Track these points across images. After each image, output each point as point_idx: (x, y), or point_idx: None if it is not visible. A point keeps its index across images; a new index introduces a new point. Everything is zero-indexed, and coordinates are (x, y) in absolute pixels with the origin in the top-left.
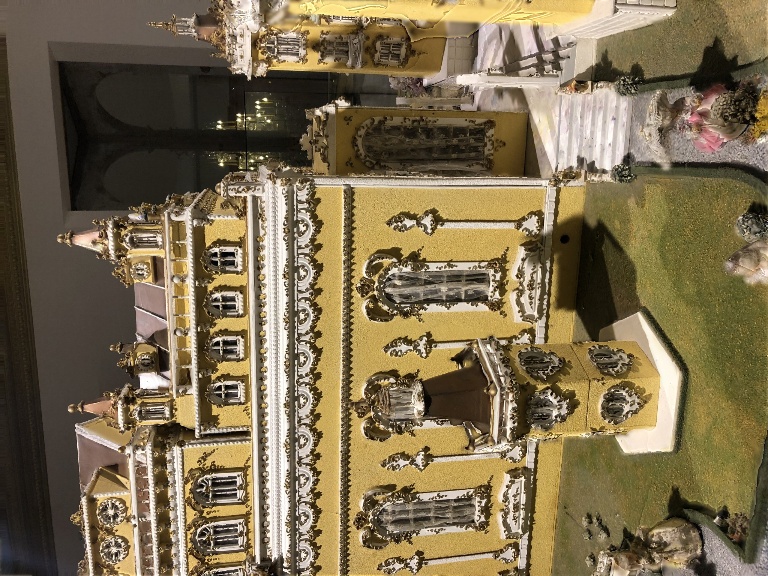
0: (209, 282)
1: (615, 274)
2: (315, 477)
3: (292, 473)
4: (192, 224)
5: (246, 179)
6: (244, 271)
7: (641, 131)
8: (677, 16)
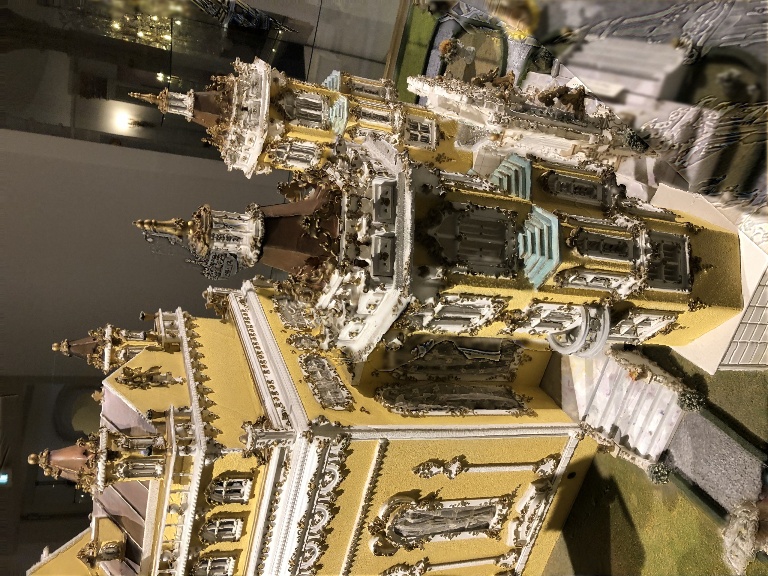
0: (209, 510)
1: (619, 541)
2: None
3: None
4: (203, 462)
5: (239, 325)
6: (249, 498)
7: (723, 534)
8: (766, 375)
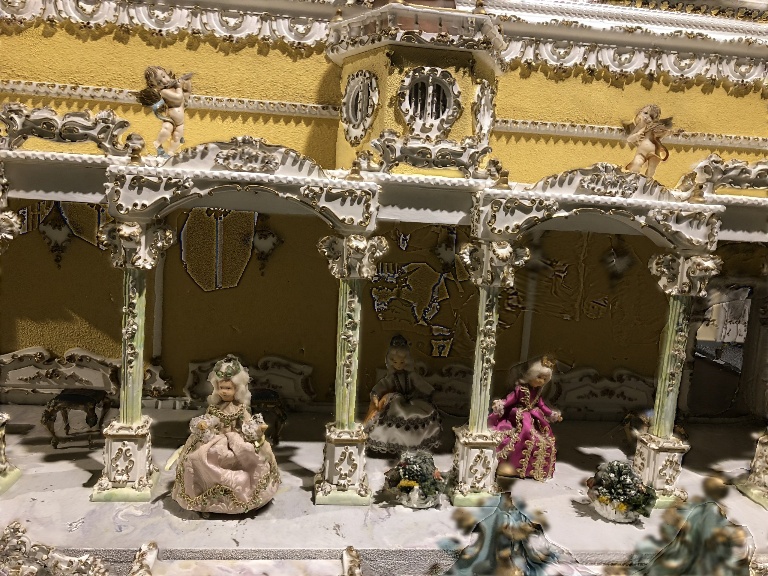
0: None
1: None
2: None
3: None
4: None
5: None
6: None
7: None
8: None
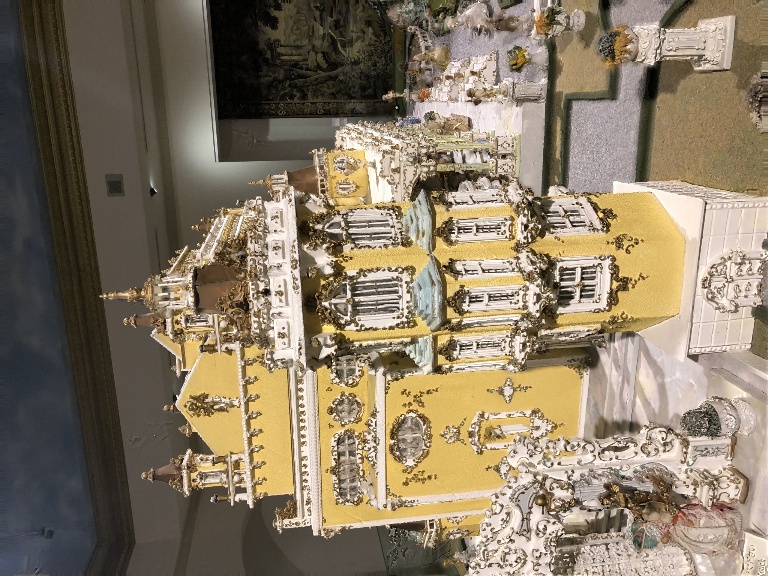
0: None
1: None
2: None
3: None
4: None
5: None
6: None
7: None
8: None
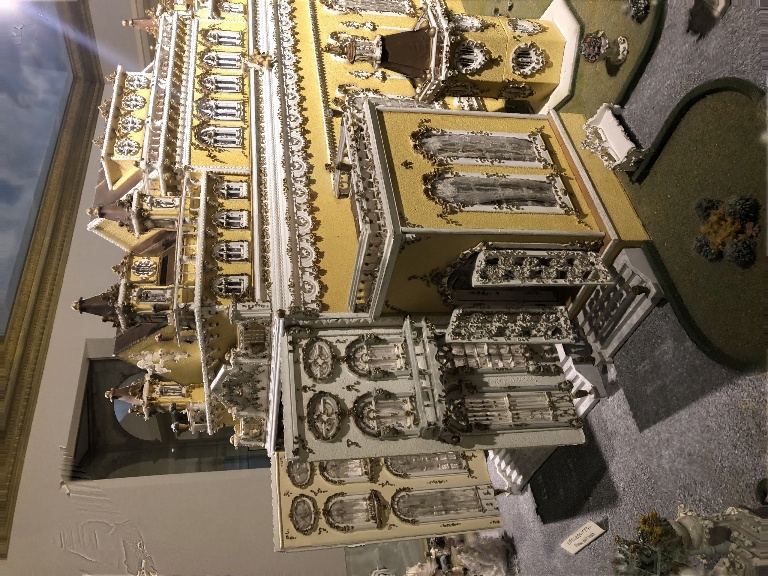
0: None
1: None
2: (293, 23)
3: (276, 18)
4: None
5: None
6: None
7: None
8: None
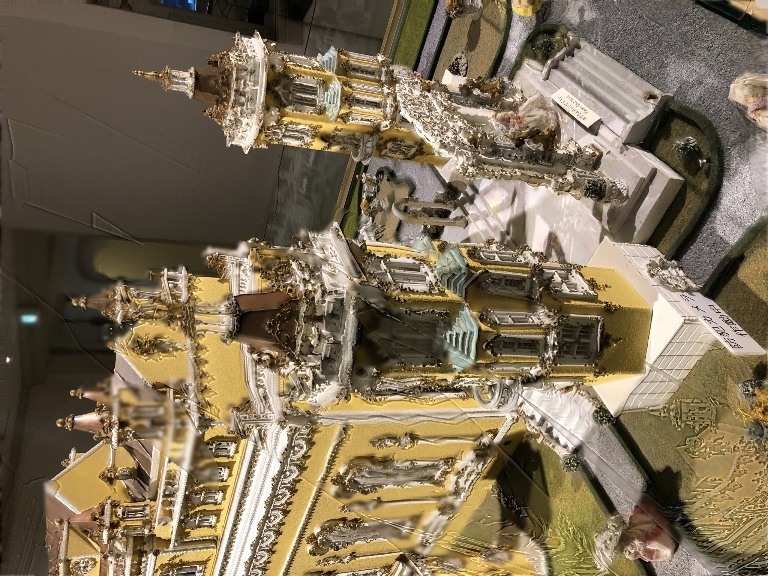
0: None
1: None
2: (263, 573)
3: (246, 574)
4: None
5: None
6: (235, 453)
7: (595, 537)
8: None
